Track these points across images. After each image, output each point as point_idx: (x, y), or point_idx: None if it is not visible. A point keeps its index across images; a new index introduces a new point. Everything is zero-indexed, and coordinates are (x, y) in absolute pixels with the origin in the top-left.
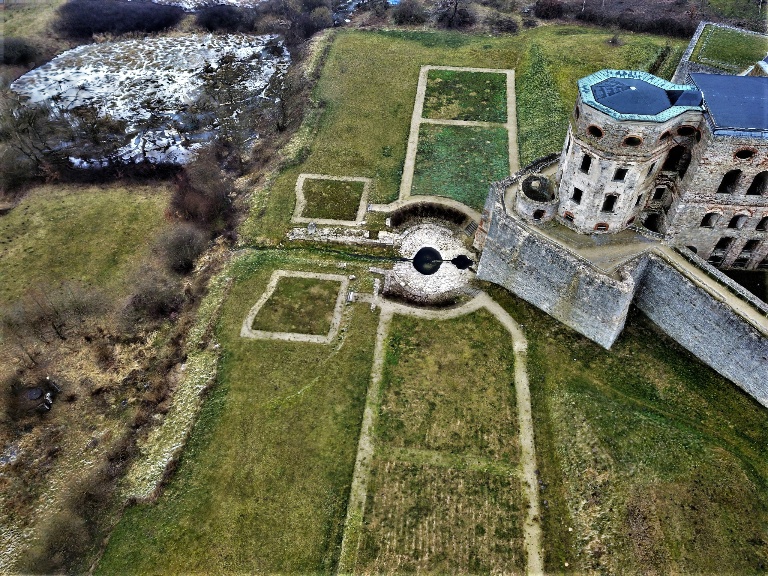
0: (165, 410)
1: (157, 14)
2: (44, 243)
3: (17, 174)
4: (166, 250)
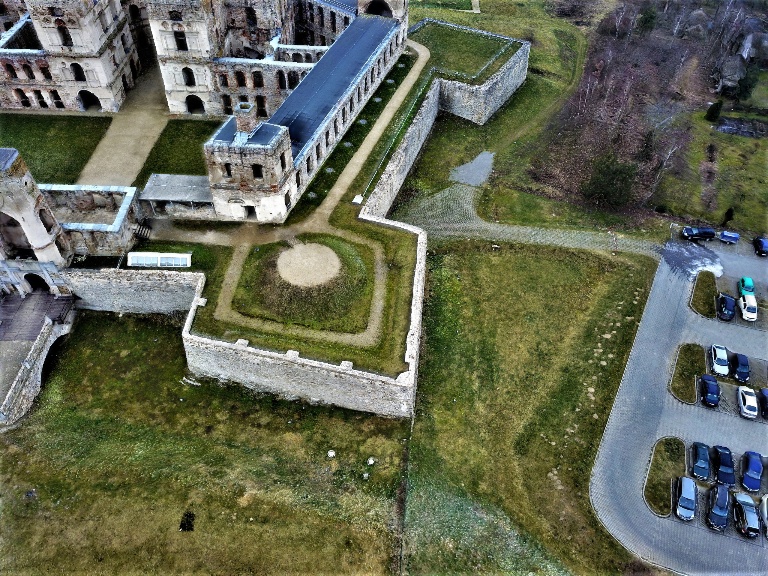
0: None
1: None
2: None
3: None
4: None
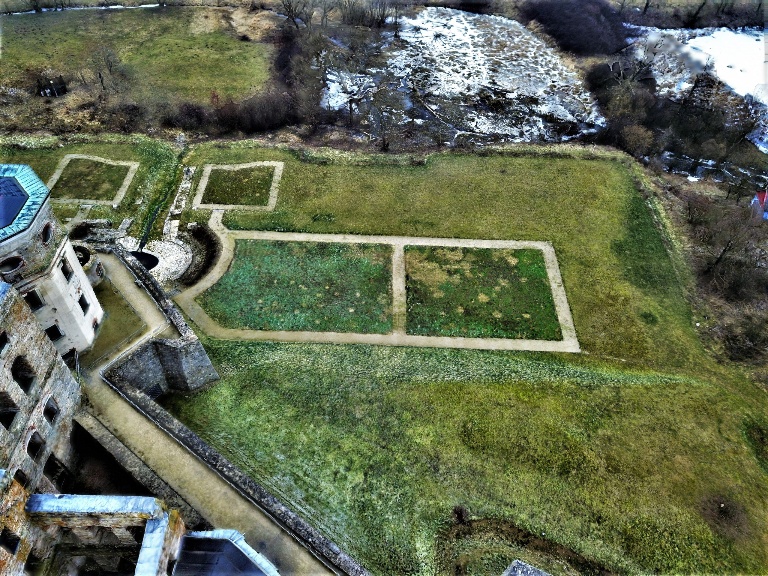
0: (11, 133)
1: (583, 38)
2: (203, 59)
3: (291, 33)
4: (188, 111)
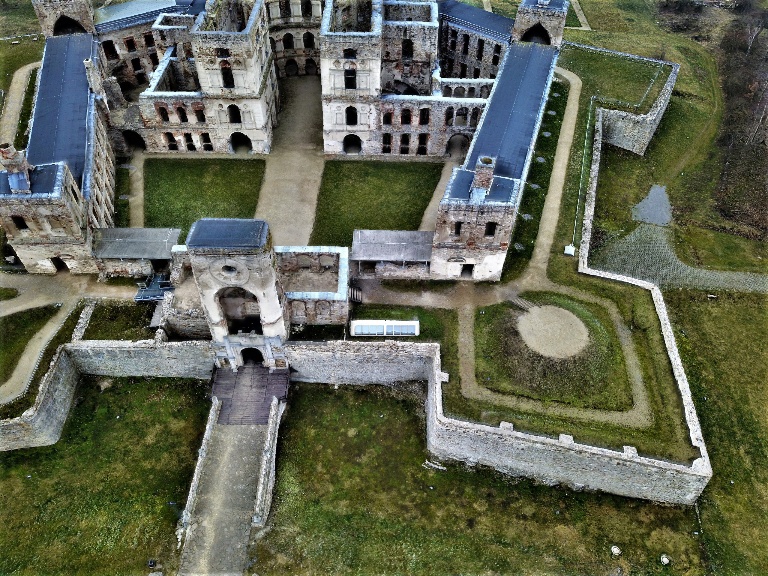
0: None
1: None
2: None
3: None
4: None
